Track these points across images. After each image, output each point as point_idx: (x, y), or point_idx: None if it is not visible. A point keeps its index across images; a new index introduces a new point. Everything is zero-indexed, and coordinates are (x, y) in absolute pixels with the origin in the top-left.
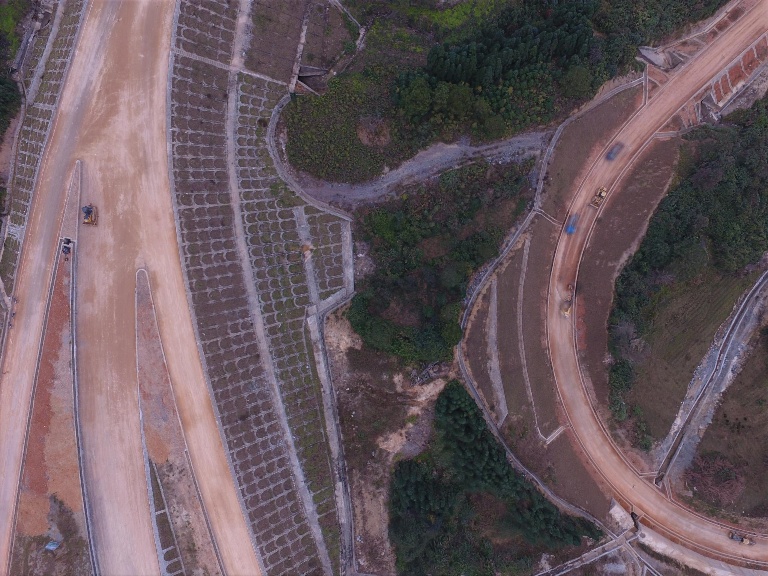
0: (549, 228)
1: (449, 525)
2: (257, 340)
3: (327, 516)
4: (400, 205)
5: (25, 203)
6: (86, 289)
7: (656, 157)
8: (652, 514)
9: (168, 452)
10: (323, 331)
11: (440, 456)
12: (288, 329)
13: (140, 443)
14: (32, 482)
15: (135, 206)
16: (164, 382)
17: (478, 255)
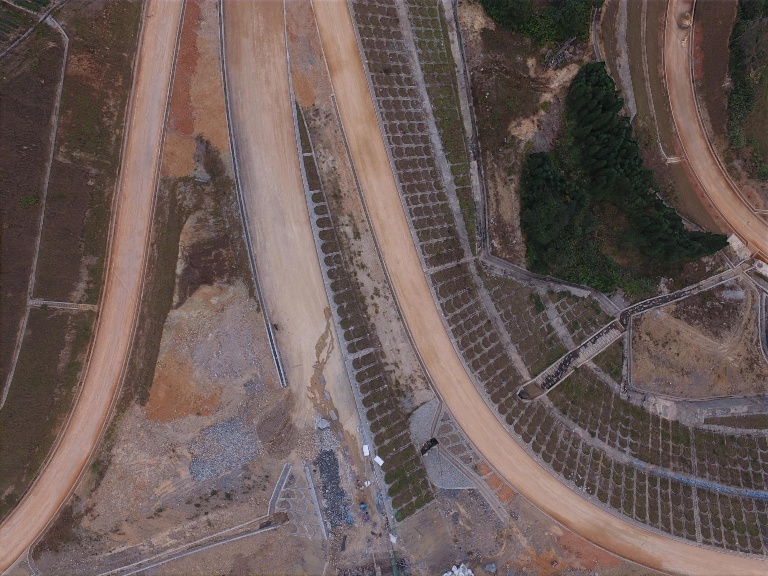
0: None
1: (574, 230)
2: (396, 6)
3: (464, 189)
4: None
5: None
6: None
7: None
8: (766, 252)
9: (315, 96)
10: (456, 13)
11: (568, 154)
12: (424, 3)
13: (287, 86)
14: (178, 123)
15: None
16: (311, 25)
17: None
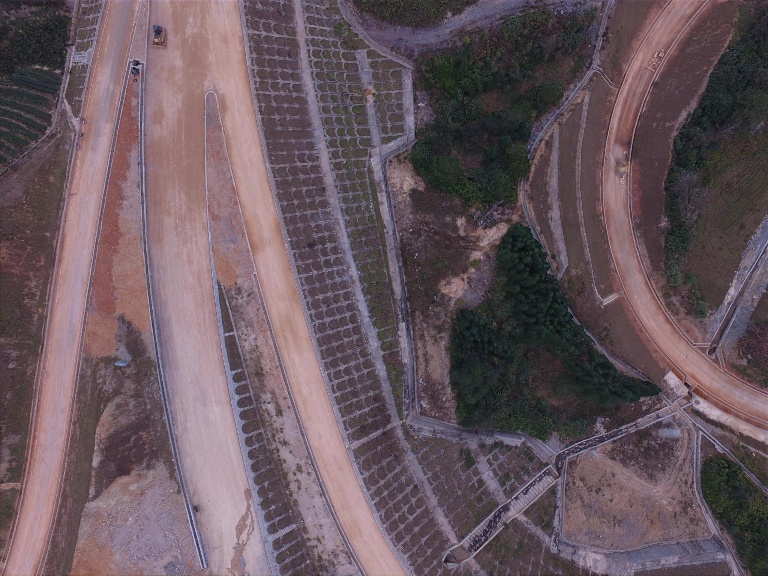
0: (606, 90)
1: (507, 379)
2: (323, 174)
3: (391, 354)
4: (462, 52)
5: (93, 27)
6: (155, 111)
7: (714, 18)
8: (705, 385)
9: (237, 275)
10: (386, 173)
11: (500, 306)
12: (352, 167)
13: (209, 265)
14: (100, 303)
15: (204, 29)
16: (233, 204)
17: (541, 101)
